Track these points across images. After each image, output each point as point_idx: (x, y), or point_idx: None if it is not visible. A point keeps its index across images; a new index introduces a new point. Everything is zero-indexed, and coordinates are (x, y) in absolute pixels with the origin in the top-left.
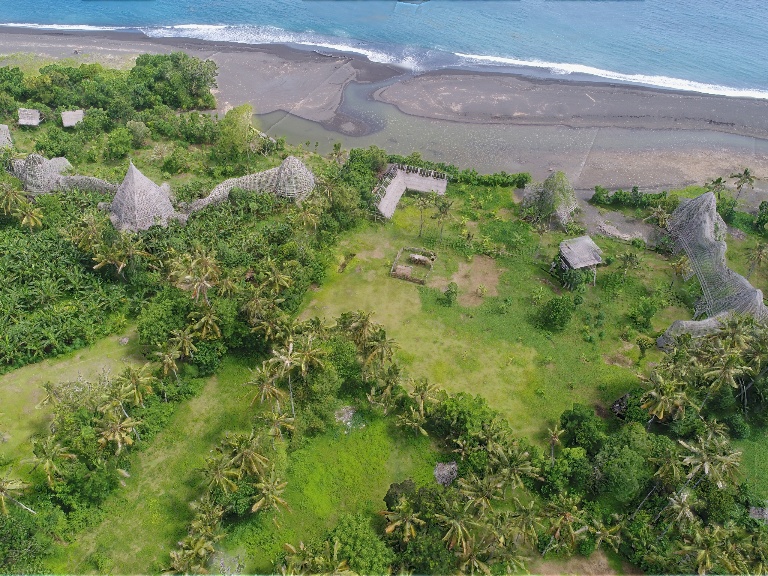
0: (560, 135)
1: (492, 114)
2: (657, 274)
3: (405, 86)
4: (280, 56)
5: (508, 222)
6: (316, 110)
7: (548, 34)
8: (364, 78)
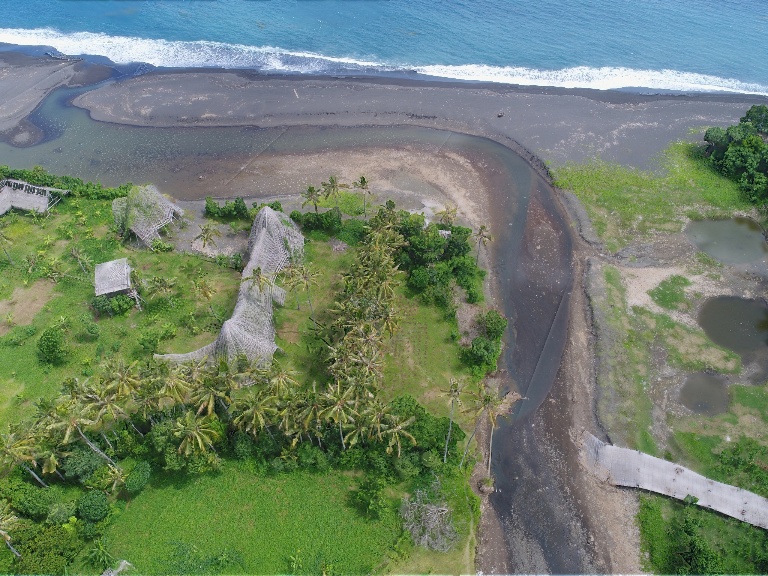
0: (240, 137)
1: (178, 117)
2: (218, 295)
3: (112, 89)
4: (6, 61)
5: (99, 240)
6: (1, 120)
7: (312, 22)
8: (77, 81)
